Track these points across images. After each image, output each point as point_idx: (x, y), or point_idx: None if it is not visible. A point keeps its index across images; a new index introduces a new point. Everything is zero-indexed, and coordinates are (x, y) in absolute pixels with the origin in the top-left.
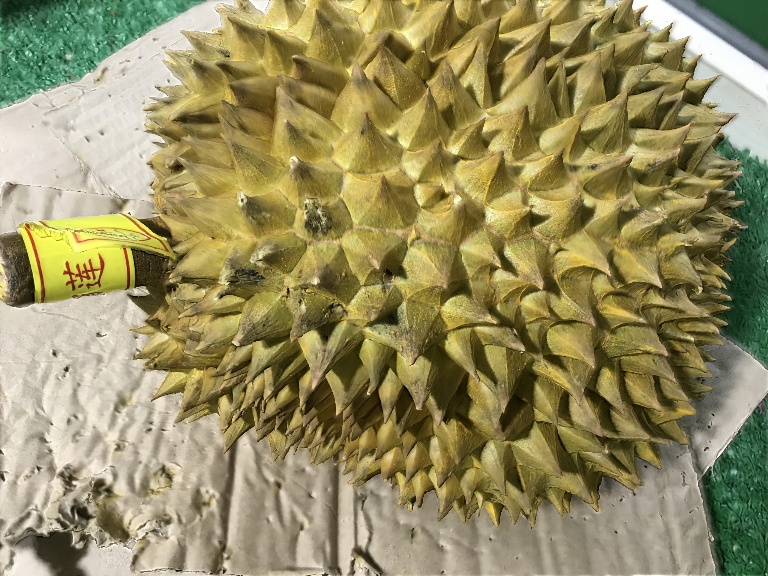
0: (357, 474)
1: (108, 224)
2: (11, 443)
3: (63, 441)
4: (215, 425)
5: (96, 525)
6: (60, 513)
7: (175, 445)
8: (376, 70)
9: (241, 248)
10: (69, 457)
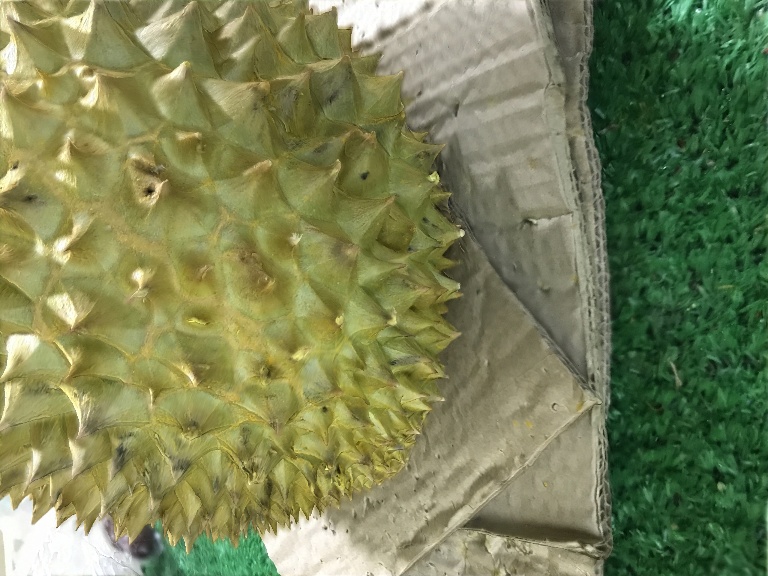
0: None
1: None
2: None
3: None
4: None
5: None
6: None
7: None
8: None
9: None
10: None
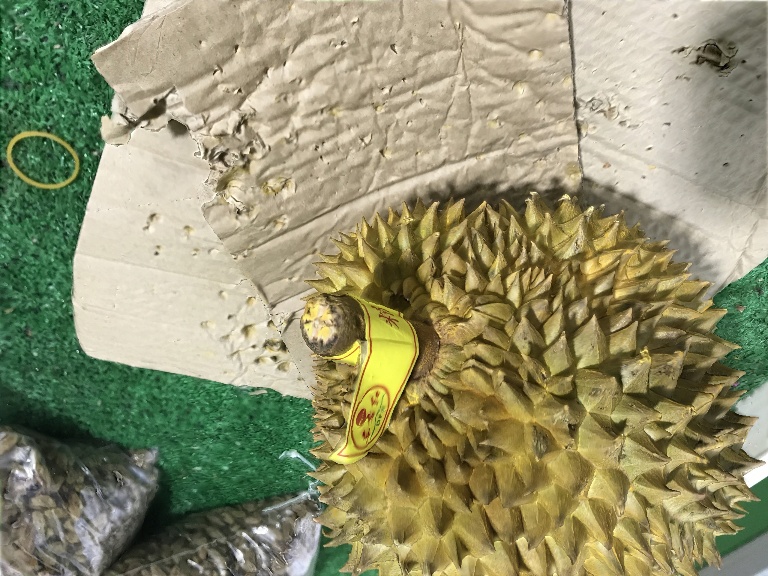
0: (317, 393)
1: (391, 379)
2: (249, 51)
3: (273, 89)
4: (343, 191)
5: (218, 179)
6: (211, 151)
7: (312, 175)
8: (533, 575)
9: (377, 514)
10: (262, 105)
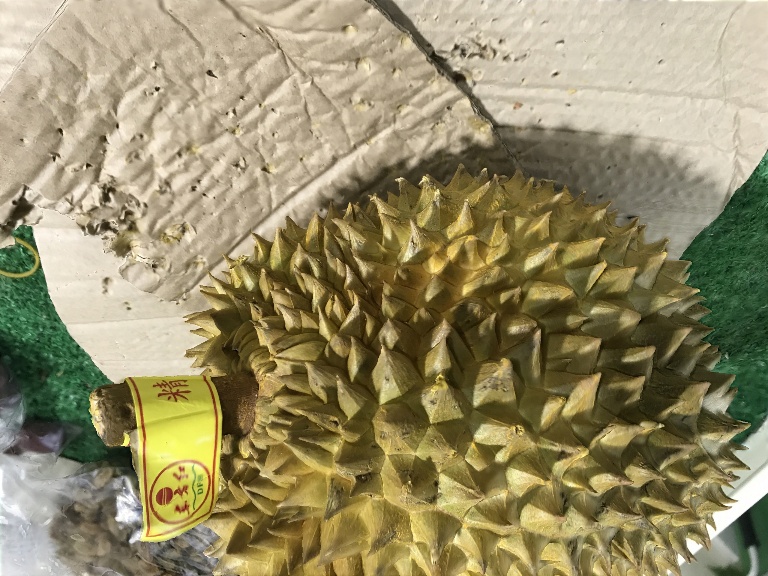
0: None
1: (194, 450)
2: (73, 129)
3: (119, 153)
4: (245, 217)
5: (109, 247)
6: (87, 227)
7: (204, 213)
8: None
9: (240, 570)
10: (117, 170)
